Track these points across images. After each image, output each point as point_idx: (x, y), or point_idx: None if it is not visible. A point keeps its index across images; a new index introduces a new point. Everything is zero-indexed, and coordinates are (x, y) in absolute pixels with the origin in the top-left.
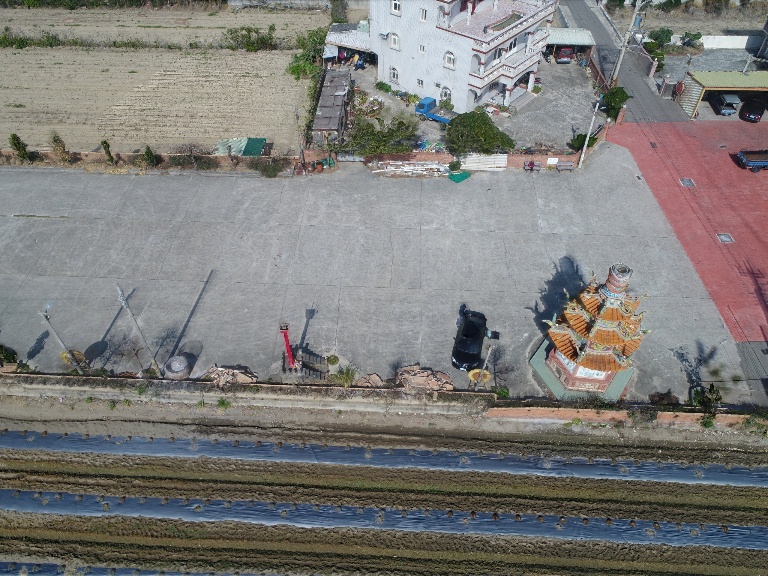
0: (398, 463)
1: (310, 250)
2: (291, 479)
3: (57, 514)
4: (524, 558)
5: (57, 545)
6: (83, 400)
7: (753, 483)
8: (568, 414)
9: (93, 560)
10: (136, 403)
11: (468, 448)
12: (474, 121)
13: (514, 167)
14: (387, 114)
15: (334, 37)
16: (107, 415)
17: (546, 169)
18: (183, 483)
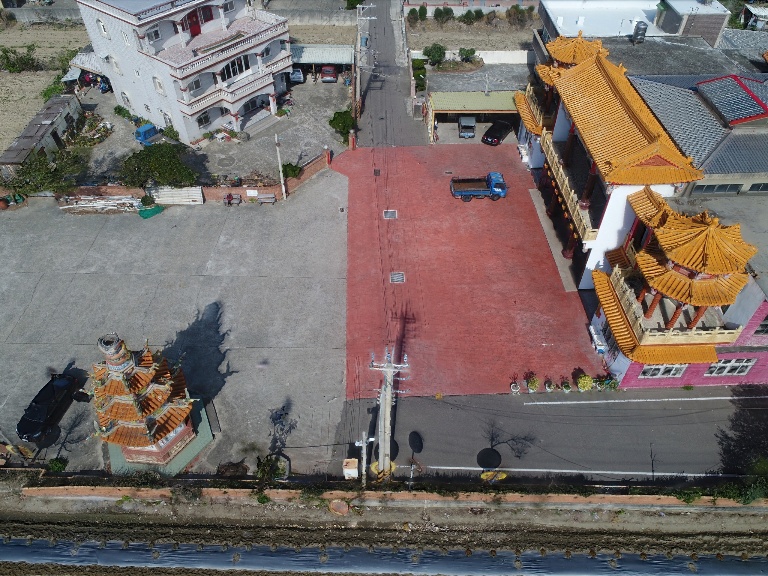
0: None
1: None
2: None
3: None
4: None
5: None
6: None
7: (291, 567)
8: (112, 492)
9: None
10: None
11: None
12: (156, 153)
13: (215, 200)
14: (111, 142)
15: (80, 58)
16: None
17: (248, 202)
18: None
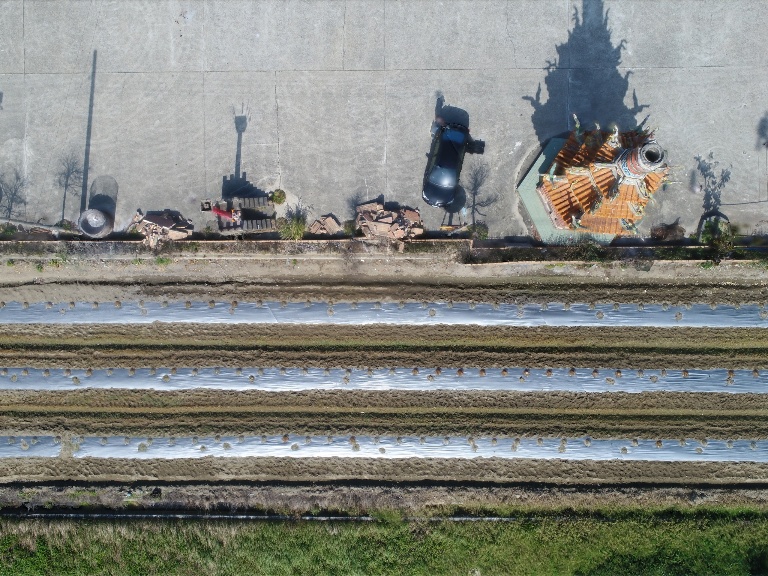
0: (362, 319)
1: (224, 1)
2: (253, 342)
3: (31, 390)
4: (484, 410)
5: (44, 418)
6: (4, 262)
7: (732, 324)
8: None
9: (83, 431)
10: (64, 263)
11: (437, 298)
12: None
13: None
14: None
15: None
16: (38, 277)
17: None
18: (144, 352)
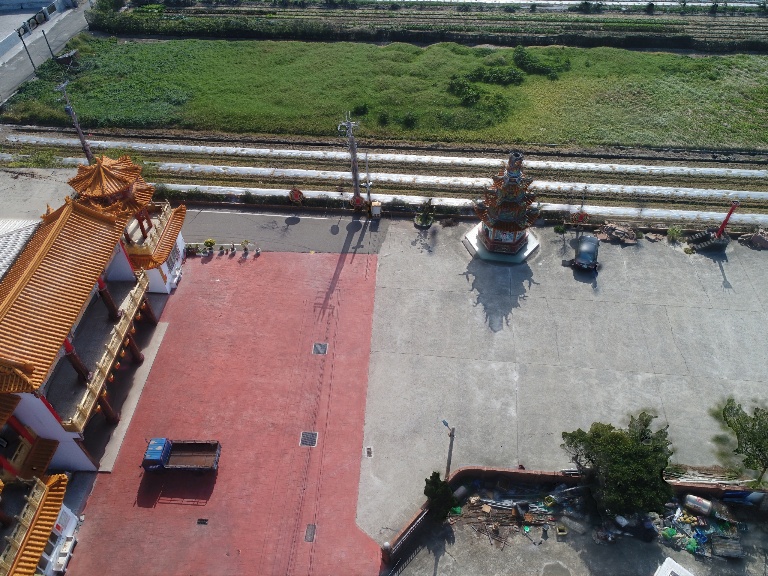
0: (619, 208)
1: (767, 349)
2: None
3: None
4: None
5: None
6: None
7: None
8: None
9: (767, 178)
10: None
11: None
12: None
13: None
14: None
15: None
16: None
17: None
18: (745, 204)
